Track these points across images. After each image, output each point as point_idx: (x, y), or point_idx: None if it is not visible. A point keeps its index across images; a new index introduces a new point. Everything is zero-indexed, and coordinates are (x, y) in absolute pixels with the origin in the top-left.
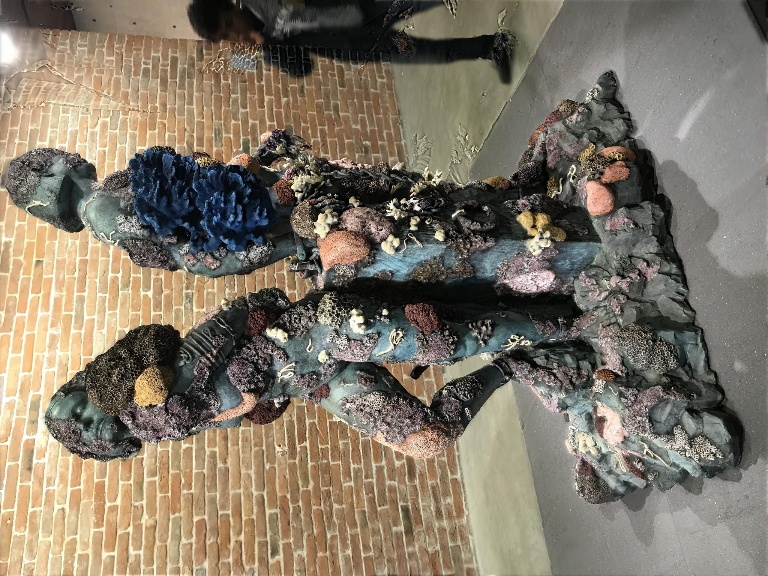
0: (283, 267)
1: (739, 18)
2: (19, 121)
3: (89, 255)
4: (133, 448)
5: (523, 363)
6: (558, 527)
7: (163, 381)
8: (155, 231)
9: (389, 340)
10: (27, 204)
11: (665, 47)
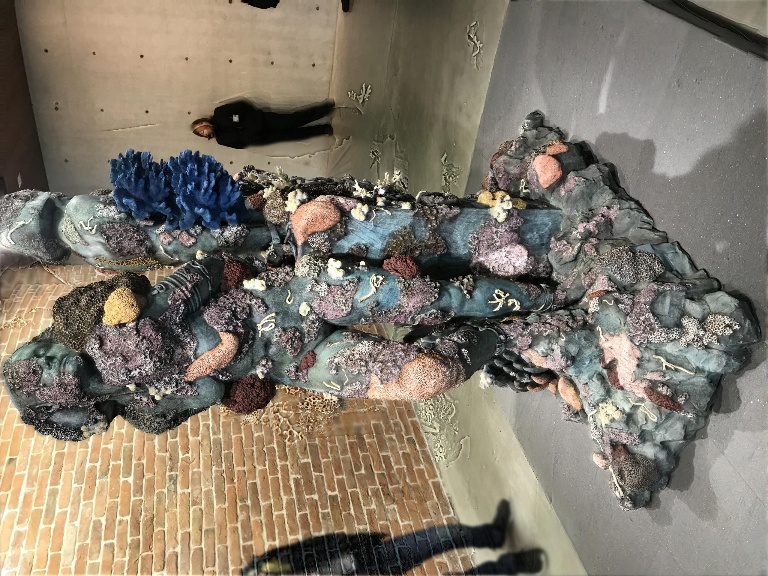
0: (273, 441)
1: (613, 0)
2: (8, 338)
3: (67, 449)
4: (100, 415)
5: (515, 323)
6: None
7: (135, 299)
8: (132, 216)
9: (370, 284)
10: (10, 229)
11: (569, 61)
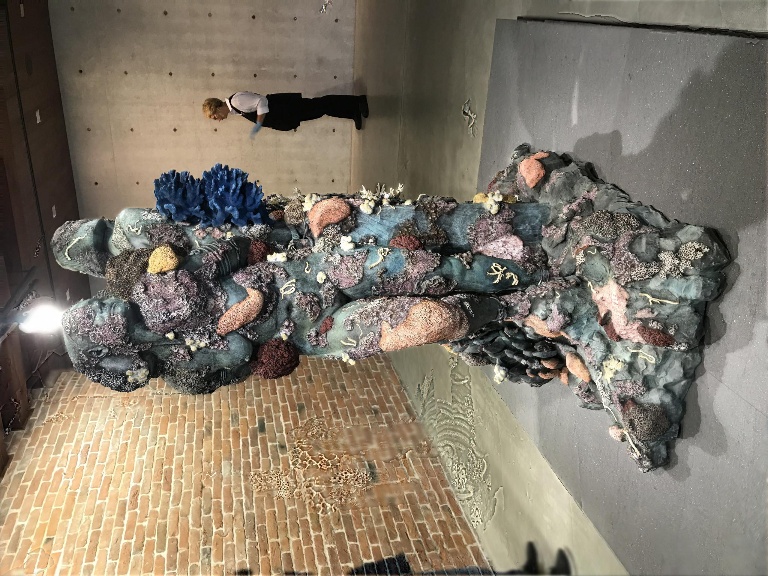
0: (306, 513)
1: (571, 32)
2: (50, 431)
3: (102, 528)
4: (142, 362)
5: None
6: (655, 569)
7: (174, 254)
8: (172, 218)
9: (378, 254)
10: (68, 246)
11: (544, 93)
